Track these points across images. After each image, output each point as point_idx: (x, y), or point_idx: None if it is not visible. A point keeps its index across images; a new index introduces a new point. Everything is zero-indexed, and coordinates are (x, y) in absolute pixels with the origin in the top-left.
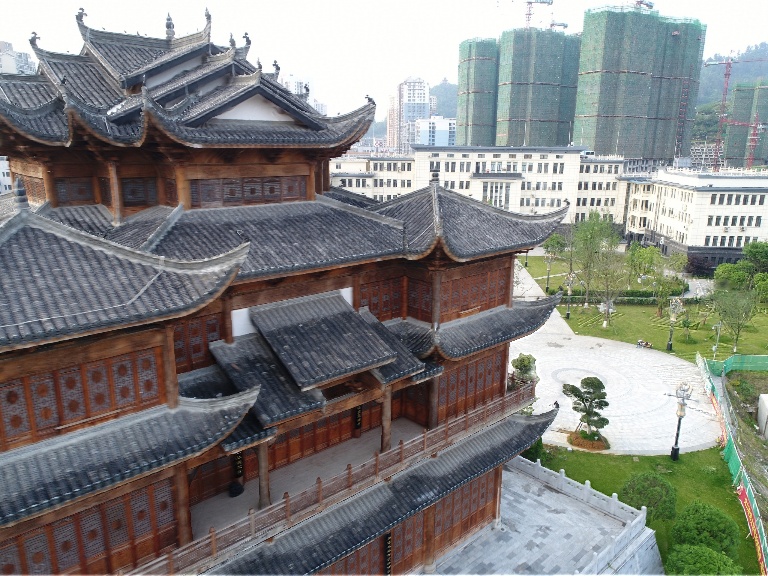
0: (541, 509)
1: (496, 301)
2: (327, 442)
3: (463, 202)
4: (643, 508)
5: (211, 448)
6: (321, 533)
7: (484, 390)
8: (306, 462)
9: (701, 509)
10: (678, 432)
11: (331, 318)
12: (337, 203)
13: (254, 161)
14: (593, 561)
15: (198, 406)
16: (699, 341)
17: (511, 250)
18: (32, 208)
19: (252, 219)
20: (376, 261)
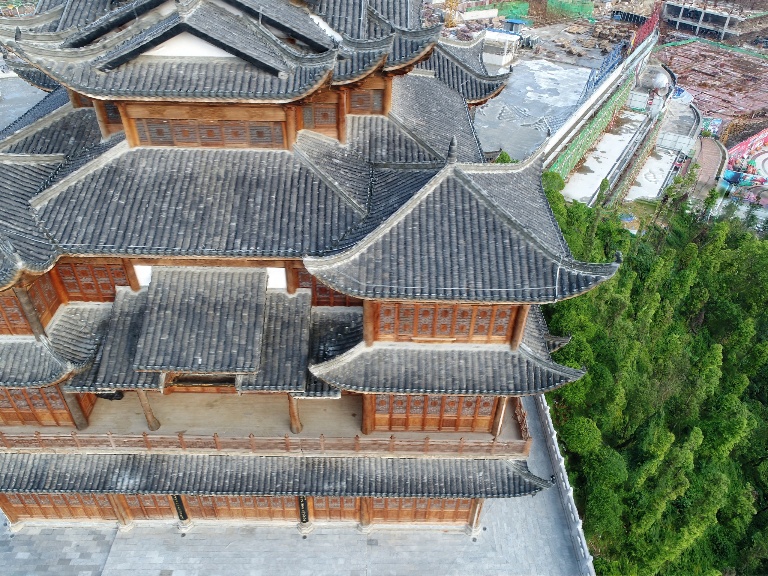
0: None
1: None
2: None
3: None
4: None
5: None
6: None
7: None
8: None
9: None
10: None
11: None
12: None
13: None
14: None
15: None
16: None
17: None
18: (394, 83)
19: None
20: None
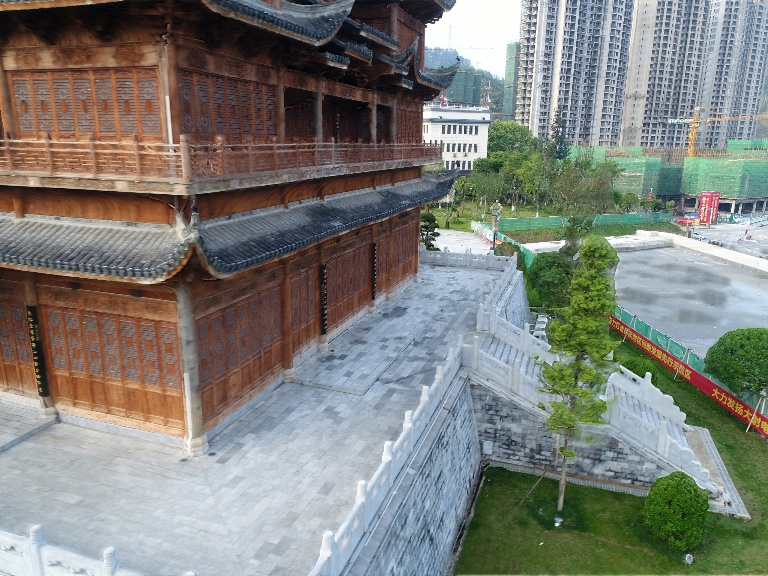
0: (441, 272)
1: None
2: None
3: None
4: (515, 252)
5: (323, 44)
6: (354, 204)
7: None
8: None
9: (546, 254)
10: (494, 245)
11: None
12: None
13: None
14: (505, 273)
15: (300, 11)
16: (464, 222)
17: (439, 2)
18: None
19: None
20: None
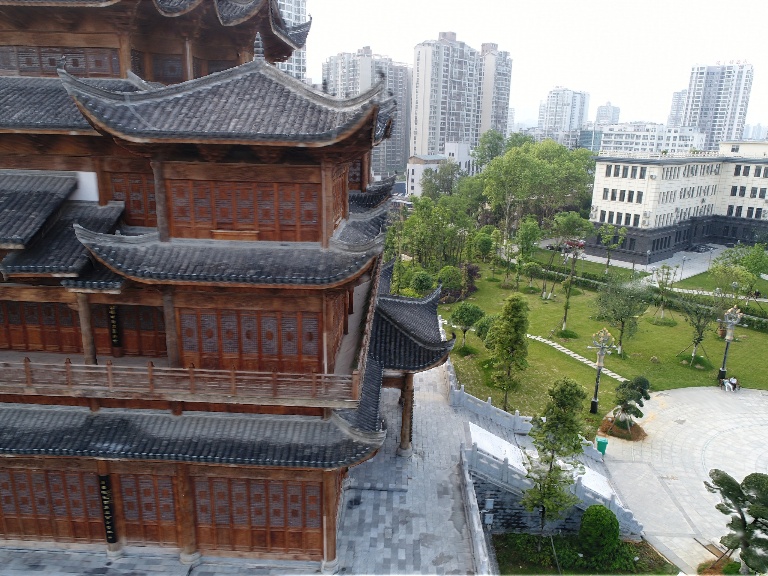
0: None
1: (298, 232)
2: (77, 347)
3: (279, 83)
4: None
5: None
6: None
7: (280, 360)
8: (39, 355)
9: None
10: None
11: (22, 193)
12: (137, 80)
13: (49, 28)
14: None
15: None
16: None
17: (248, 141)
18: None
19: (19, 86)
20: (71, 134)
